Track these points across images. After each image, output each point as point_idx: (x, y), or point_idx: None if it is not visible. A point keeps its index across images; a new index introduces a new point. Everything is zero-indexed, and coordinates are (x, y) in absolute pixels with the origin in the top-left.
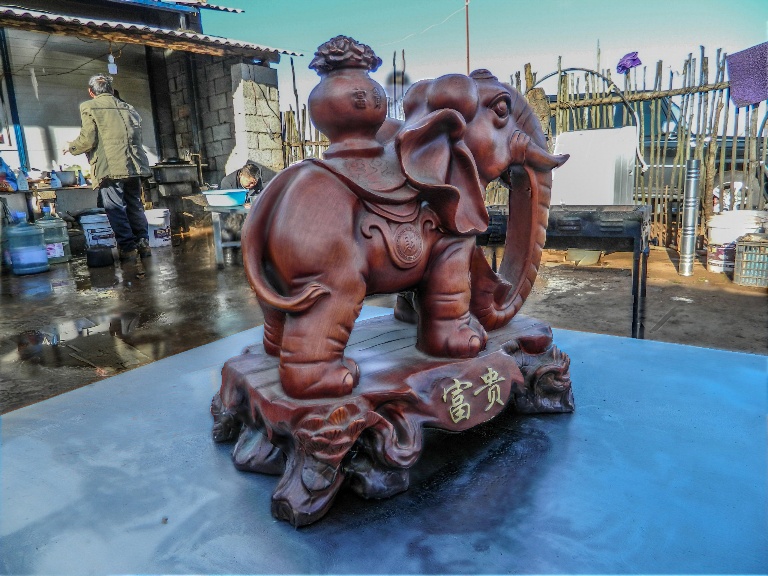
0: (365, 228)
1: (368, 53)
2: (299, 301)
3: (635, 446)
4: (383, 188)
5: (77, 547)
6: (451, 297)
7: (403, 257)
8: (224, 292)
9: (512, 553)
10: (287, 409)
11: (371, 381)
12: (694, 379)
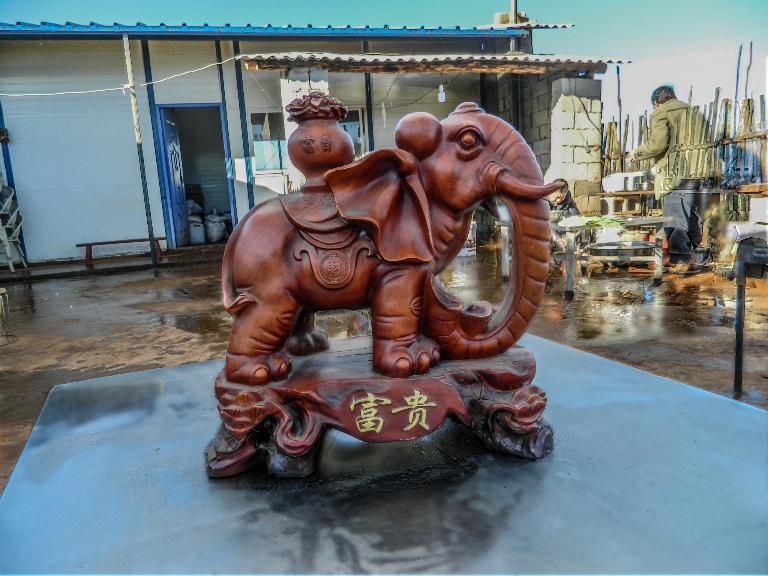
0: (296, 252)
1: (330, 105)
2: (231, 306)
3: (543, 506)
4: (317, 219)
5: (105, 449)
6: (387, 319)
7: (326, 279)
8: (493, 303)
9: (303, 544)
10: (216, 386)
11: (297, 380)
12: (747, 466)
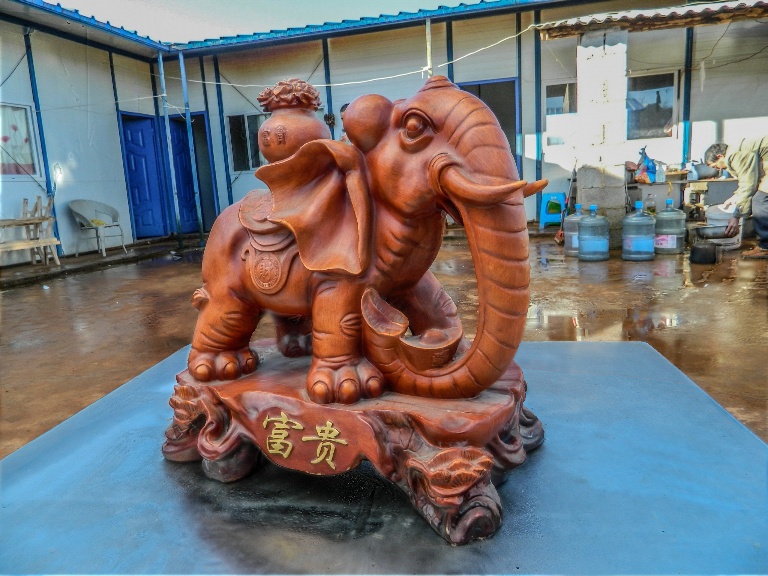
0: (242, 251)
1: (294, 92)
2: None
3: None
4: (260, 218)
5: (143, 409)
6: (317, 335)
7: (258, 282)
8: None
9: (136, 551)
10: None
11: (241, 383)
12: None
